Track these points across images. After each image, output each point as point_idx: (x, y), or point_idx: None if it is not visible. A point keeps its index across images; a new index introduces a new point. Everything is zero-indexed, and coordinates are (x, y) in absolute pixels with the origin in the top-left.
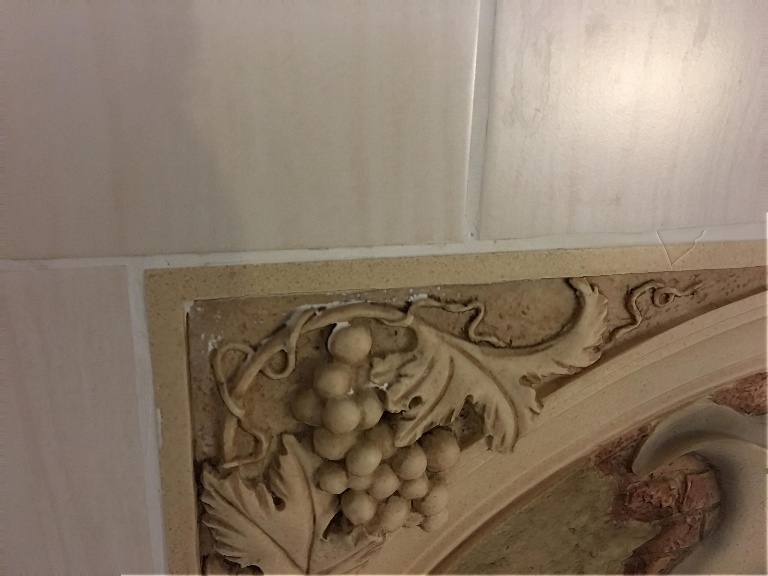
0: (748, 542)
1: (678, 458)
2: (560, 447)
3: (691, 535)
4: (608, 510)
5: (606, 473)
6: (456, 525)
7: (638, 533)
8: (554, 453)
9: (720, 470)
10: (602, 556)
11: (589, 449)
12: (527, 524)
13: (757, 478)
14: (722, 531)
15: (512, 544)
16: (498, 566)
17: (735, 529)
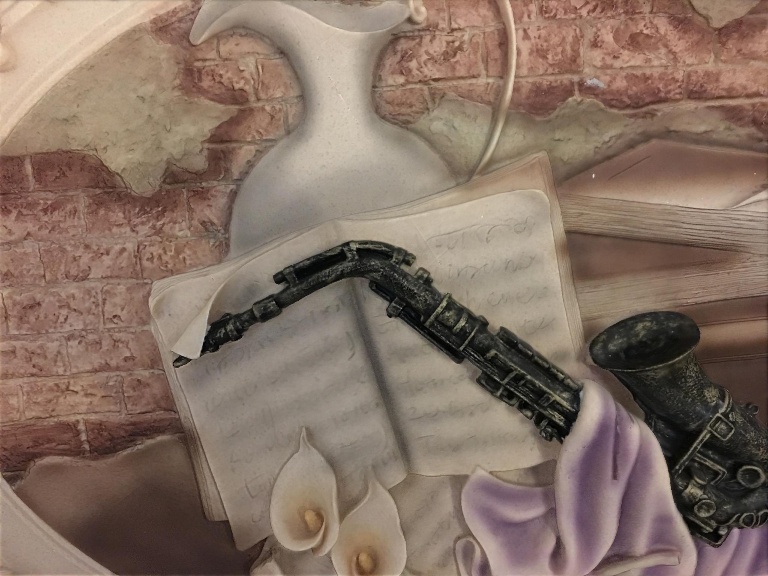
0: (329, 133)
1: (244, 39)
2: (116, 11)
3: (274, 126)
4: (175, 83)
5: (166, 42)
6: (33, 81)
7: (211, 112)
8: (111, 16)
9: (288, 53)
10: (177, 131)
11: (143, 14)
12: (92, 83)
13: (317, 55)
14: (306, 124)
15: (82, 103)
16: (72, 124)
17: (316, 120)
